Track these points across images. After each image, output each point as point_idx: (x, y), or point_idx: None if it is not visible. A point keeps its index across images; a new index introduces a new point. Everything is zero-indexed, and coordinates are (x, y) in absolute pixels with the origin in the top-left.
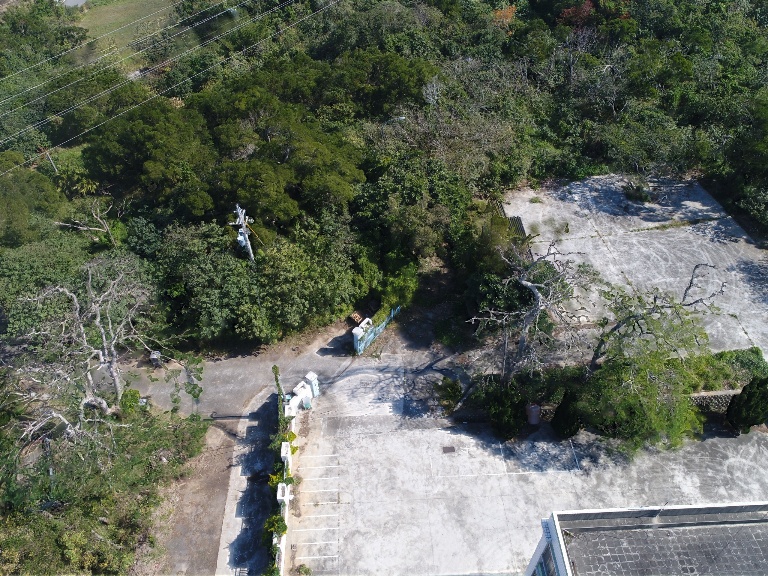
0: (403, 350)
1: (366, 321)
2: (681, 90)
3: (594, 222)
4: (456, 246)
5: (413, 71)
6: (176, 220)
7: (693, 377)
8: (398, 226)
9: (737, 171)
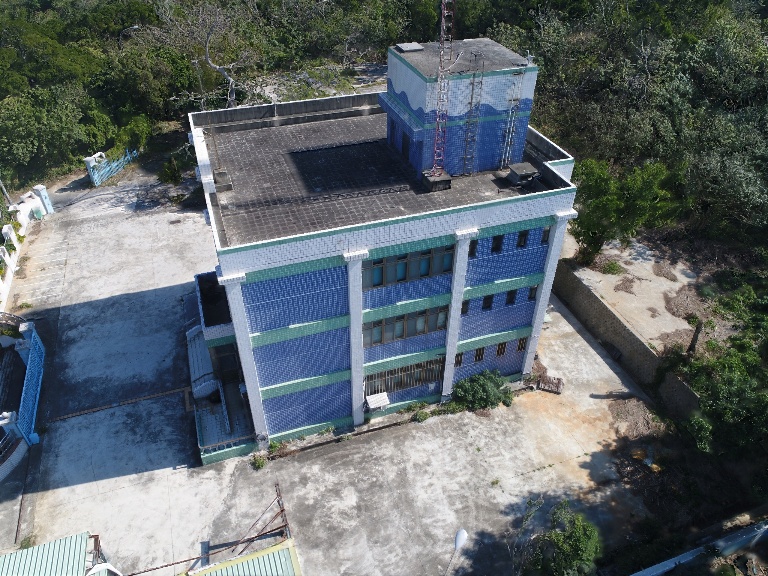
0: (139, 177)
1: (98, 154)
2: (382, 10)
3: None
4: None
5: (151, 7)
6: None
7: None
8: (119, 74)
9: None
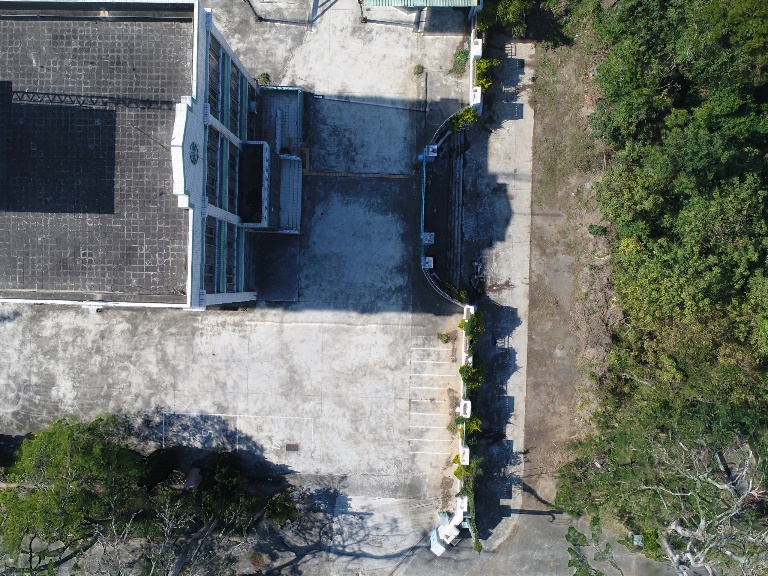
0: None
1: None
2: None
3: None
4: None
5: None
6: None
7: (5, 508)
8: None
9: None
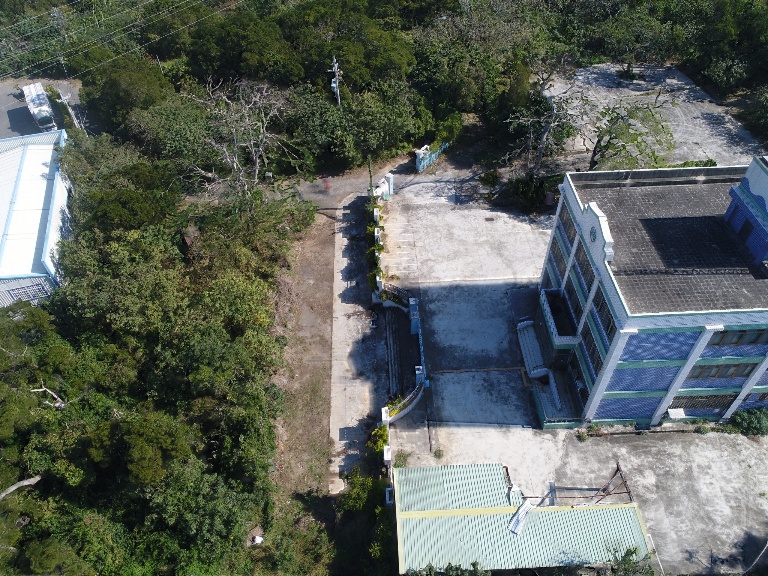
0: (452, 169)
1: (425, 147)
2: (664, 3)
3: (594, 92)
4: (488, 107)
5: None
6: (276, 85)
7: None
8: (448, 79)
9: (704, 54)
